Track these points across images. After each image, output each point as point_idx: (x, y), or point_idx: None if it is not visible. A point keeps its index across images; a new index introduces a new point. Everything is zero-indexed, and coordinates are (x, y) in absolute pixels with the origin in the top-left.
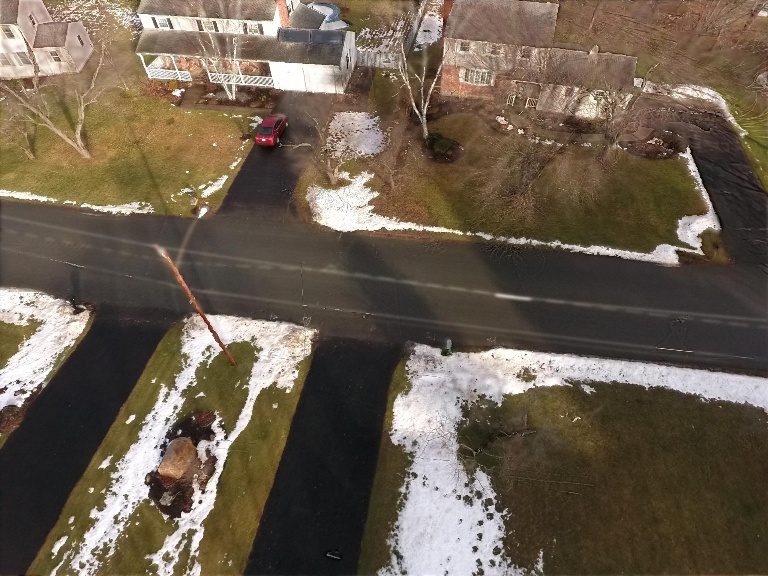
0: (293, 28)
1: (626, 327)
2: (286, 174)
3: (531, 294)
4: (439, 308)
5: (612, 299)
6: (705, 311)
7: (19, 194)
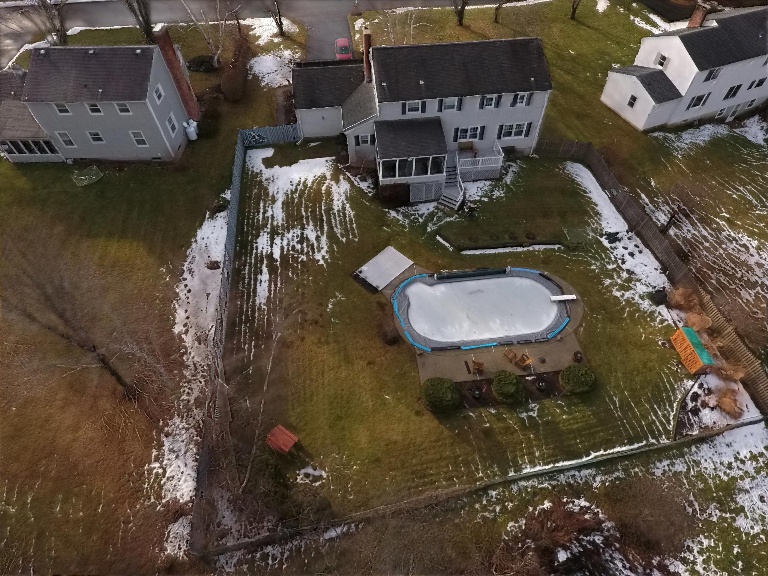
0: (353, 65)
1: (123, 7)
2: (318, 36)
3: (165, 10)
4: (213, 0)
5: (123, 13)
6: (76, 16)
7: (471, 7)
